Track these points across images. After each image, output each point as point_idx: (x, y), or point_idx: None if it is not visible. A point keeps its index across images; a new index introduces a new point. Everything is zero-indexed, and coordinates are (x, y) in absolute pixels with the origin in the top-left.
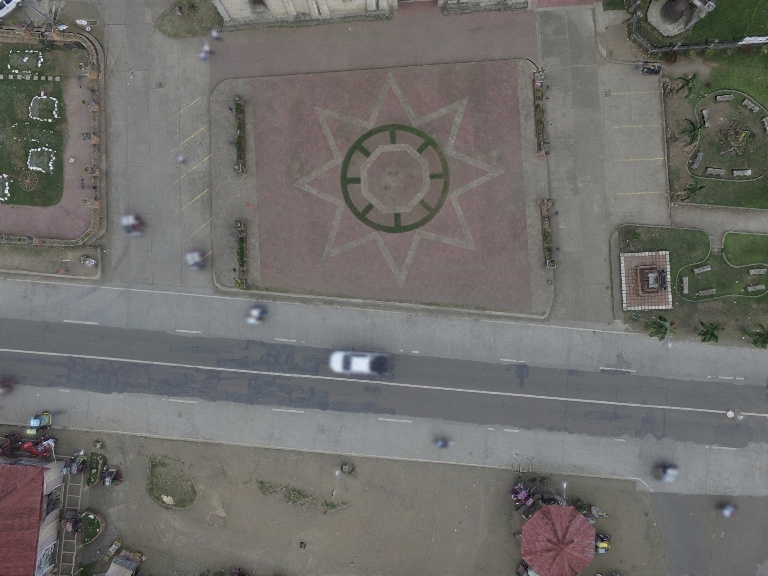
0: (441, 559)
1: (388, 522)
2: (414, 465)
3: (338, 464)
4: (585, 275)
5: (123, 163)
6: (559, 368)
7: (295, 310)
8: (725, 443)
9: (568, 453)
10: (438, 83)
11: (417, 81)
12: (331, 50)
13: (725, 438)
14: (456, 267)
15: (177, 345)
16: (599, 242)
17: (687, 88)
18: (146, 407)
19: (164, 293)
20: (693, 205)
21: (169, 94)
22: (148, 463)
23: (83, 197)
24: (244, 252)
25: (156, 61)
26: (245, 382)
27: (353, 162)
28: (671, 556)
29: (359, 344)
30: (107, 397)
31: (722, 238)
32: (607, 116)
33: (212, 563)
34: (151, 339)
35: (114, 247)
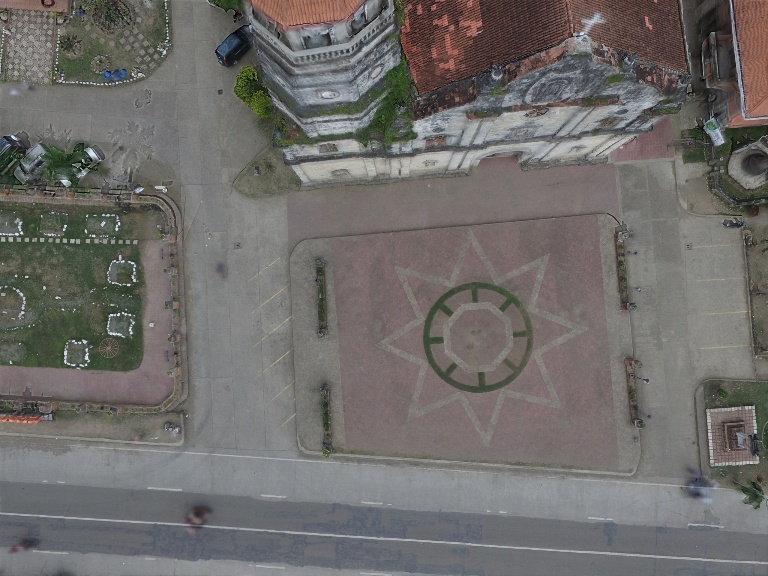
0: None
1: None
2: None
3: None
4: (671, 431)
5: (203, 326)
6: (647, 525)
7: (381, 472)
8: None
9: None
10: (519, 240)
11: (498, 238)
12: (410, 207)
13: None
14: (542, 426)
15: (263, 510)
16: (684, 397)
17: None
18: (233, 574)
19: (248, 458)
20: None
21: (248, 255)
22: None
23: (163, 361)
24: (328, 415)
25: (234, 221)
26: (332, 546)
27: (436, 321)
28: None
29: (446, 505)
30: (193, 564)
31: None
32: (689, 270)
33: None
34: (236, 505)
35: (196, 411)
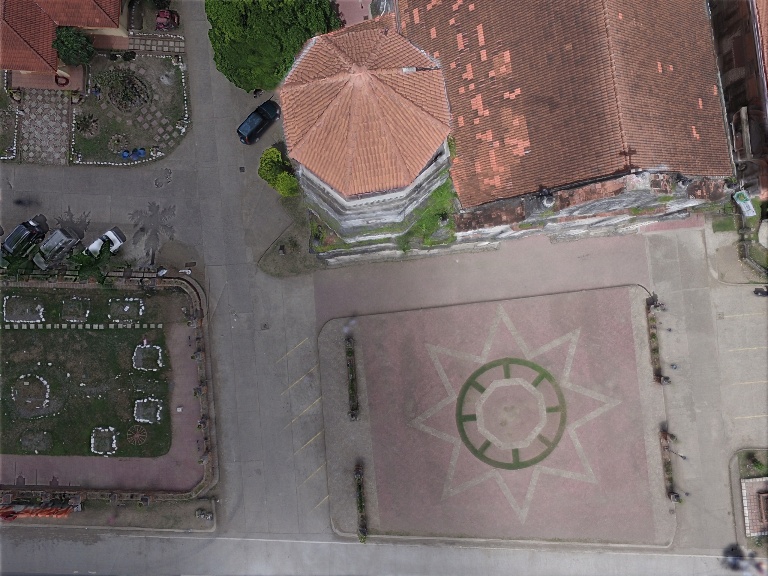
0: None
1: None
2: None
3: None
4: (706, 502)
5: (232, 409)
6: None
7: (416, 552)
8: None
9: None
10: (550, 314)
11: (528, 312)
12: (439, 283)
13: None
14: (577, 501)
15: None
16: (719, 467)
17: None
18: None
19: (282, 542)
20: None
21: (275, 335)
22: None
23: (192, 446)
24: (362, 497)
25: (260, 302)
26: None
27: (468, 398)
28: None
29: None
30: None
31: None
32: (721, 339)
33: None
34: None
35: (228, 496)
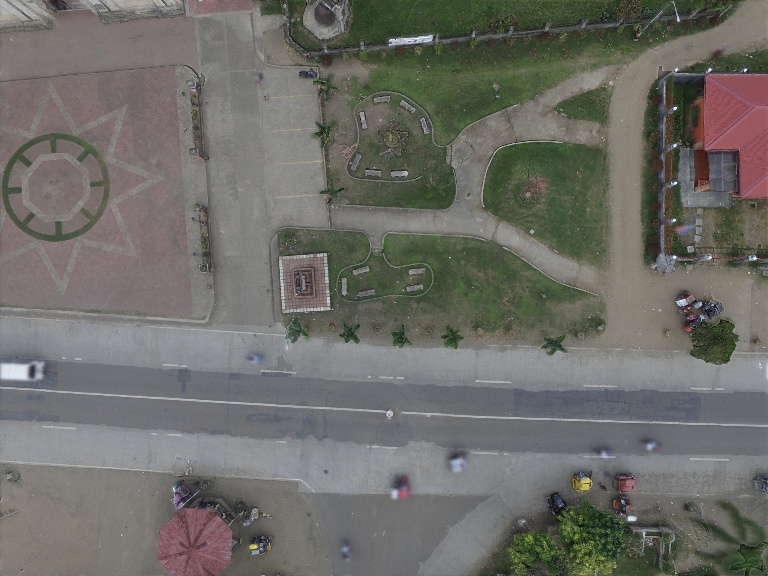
0: (108, 564)
1: (56, 528)
2: (79, 471)
3: (4, 472)
4: (246, 279)
5: None
6: (221, 372)
7: None
8: (385, 442)
9: (231, 456)
10: (98, 91)
11: (77, 90)
12: None
13: (385, 437)
14: (117, 274)
15: None
16: (259, 246)
17: (324, 91)
18: None
19: None
20: (353, 207)
21: None
22: None
23: None
24: None
25: None
26: None
27: (14, 172)
28: (333, 556)
29: (22, 352)
30: None
31: (382, 239)
32: (266, 120)
33: None
34: None
35: None
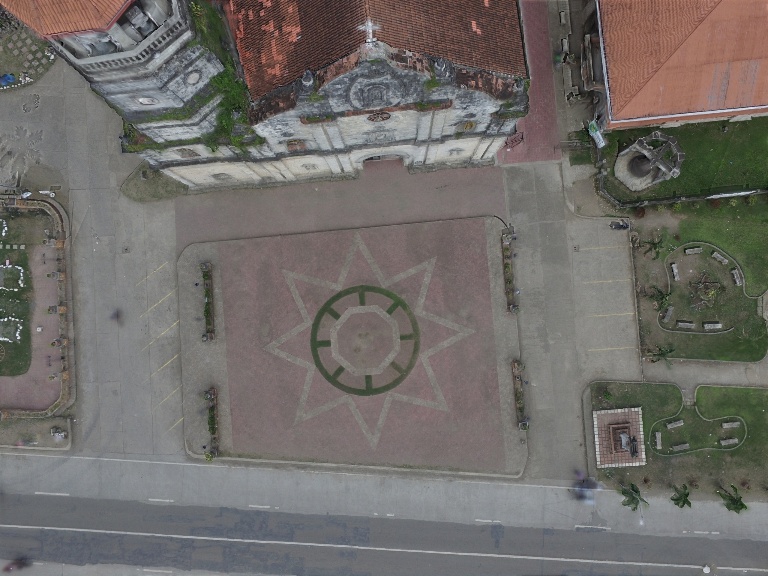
0: None
1: None
2: None
3: None
4: (558, 433)
5: (91, 330)
6: (534, 527)
7: (268, 476)
8: None
9: None
10: (406, 243)
11: (385, 241)
12: (298, 211)
13: None
14: (429, 429)
15: (150, 514)
16: (571, 399)
17: (654, 252)
18: None
19: (136, 462)
20: None
21: (136, 259)
22: None
23: (52, 366)
24: (215, 419)
25: (122, 226)
26: (220, 550)
27: (323, 325)
28: None
29: (333, 508)
30: (81, 569)
31: (694, 391)
32: (576, 272)
33: None
34: (124, 509)
35: (84, 416)
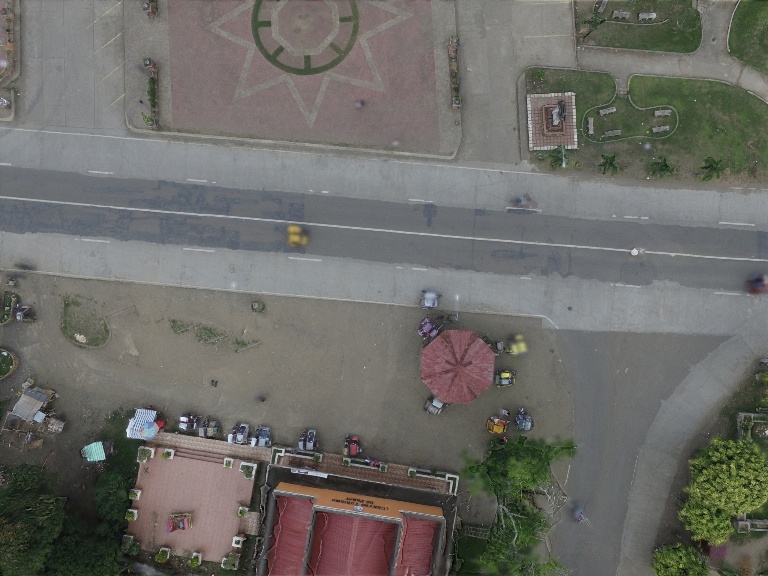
0: (350, 396)
1: (298, 360)
2: (323, 303)
3: (248, 302)
4: (492, 117)
5: (37, 8)
6: (466, 208)
7: (206, 151)
8: (629, 281)
9: (475, 291)
10: None
11: None
12: None
13: (629, 276)
14: (365, 108)
15: (90, 186)
16: (506, 84)
17: None
18: (59, 247)
19: (77, 135)
20: (599, 48)
21: None
22: (61, 302)
23: None
24: (156, 93)
25: None
26: (157, 222)
27: (264, 6)
28: (576, 391)
29: (269, 184)
30: (20, 237)
31: (628, 81)
32: None
33: (125, 401)
34: (64, 180)
35: (28, 90)
